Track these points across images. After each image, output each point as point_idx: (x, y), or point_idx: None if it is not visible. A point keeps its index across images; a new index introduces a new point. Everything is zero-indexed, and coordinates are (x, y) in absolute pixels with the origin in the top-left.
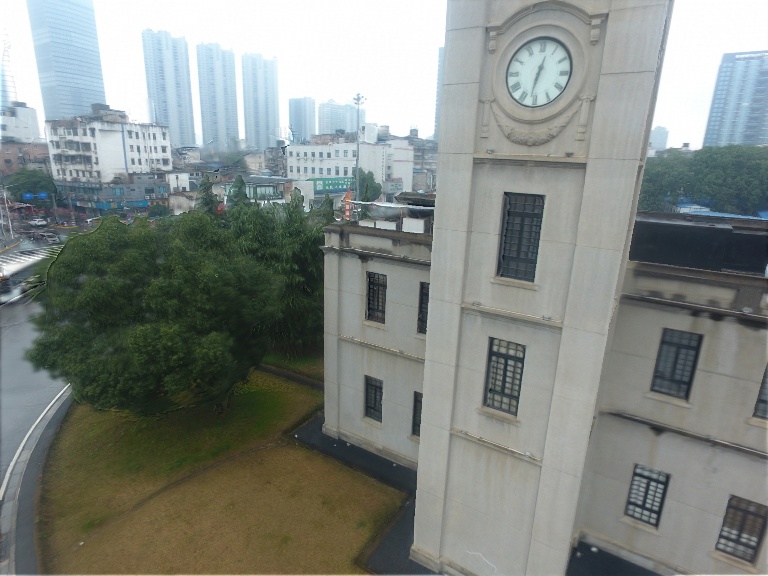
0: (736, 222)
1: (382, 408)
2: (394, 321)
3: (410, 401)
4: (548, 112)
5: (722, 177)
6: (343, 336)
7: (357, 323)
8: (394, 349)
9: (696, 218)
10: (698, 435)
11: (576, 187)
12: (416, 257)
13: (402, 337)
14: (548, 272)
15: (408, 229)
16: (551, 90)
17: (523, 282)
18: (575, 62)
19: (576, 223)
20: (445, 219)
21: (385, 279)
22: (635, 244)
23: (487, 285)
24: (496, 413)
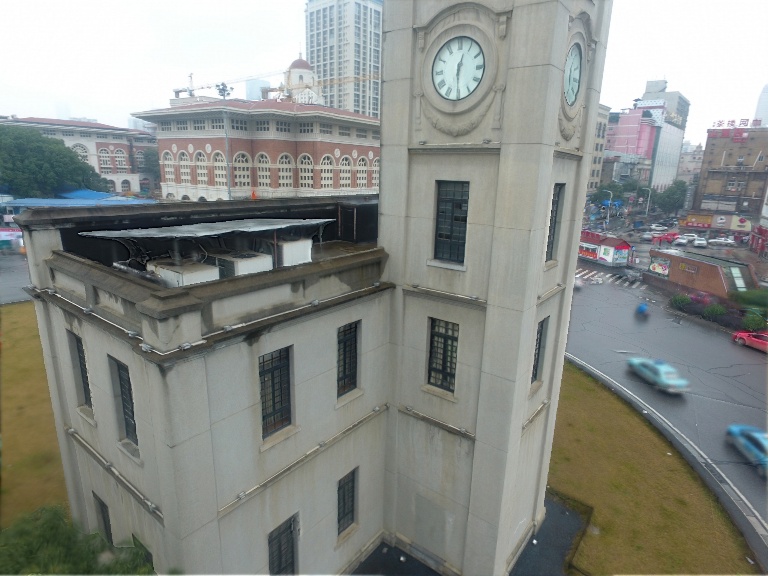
0: None
1: (299, 553)
2: (308, 408)
3: (334, 500)
4: (574, 112)
5: (10, 161)
6: (225, 508)
7: (249, 460)
8: (311, 449)
9: (369, 197)
10: None
11: (574, 175)
12: (328, 296)
13: (320, 423)
14: (561, 247)
15: (292, 260)
16: (570, 93)
17: (553, 262)
18: (584, 74)
19: (572, 203)
20: (538, 219)
21: (283, 354)
22: (364, 225)
23: (542, 275)
24: (534, 388)
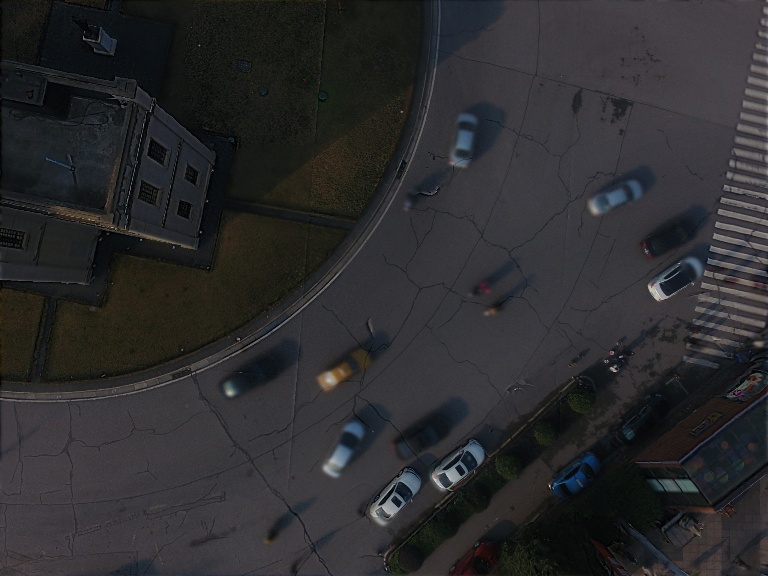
0: (50, 78)
1: None
2: None
3: None
4: None
5: None
6: None
7: None
8: None
9: (23, 72)
10: (91, 224)
11: None
12: None
13: None
14: None
15: None
16: None
17: None
18: None
19: None
20: None
21: None
22: None
23: None
24: None
